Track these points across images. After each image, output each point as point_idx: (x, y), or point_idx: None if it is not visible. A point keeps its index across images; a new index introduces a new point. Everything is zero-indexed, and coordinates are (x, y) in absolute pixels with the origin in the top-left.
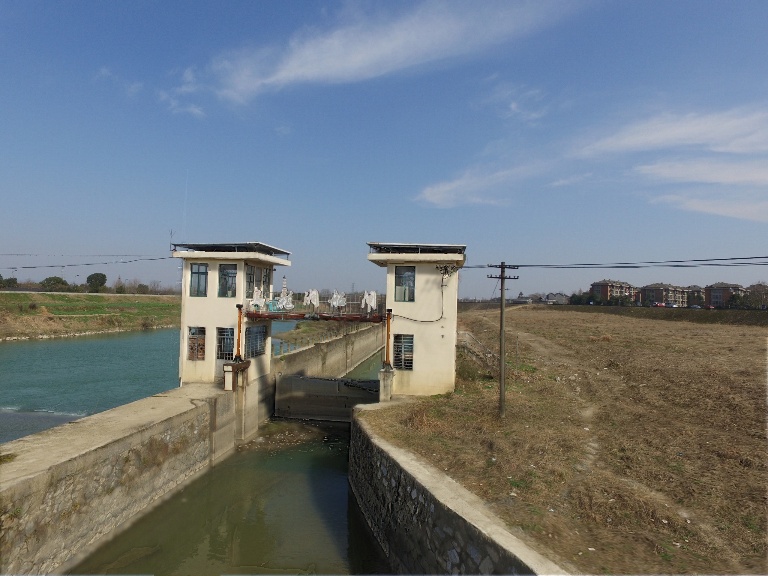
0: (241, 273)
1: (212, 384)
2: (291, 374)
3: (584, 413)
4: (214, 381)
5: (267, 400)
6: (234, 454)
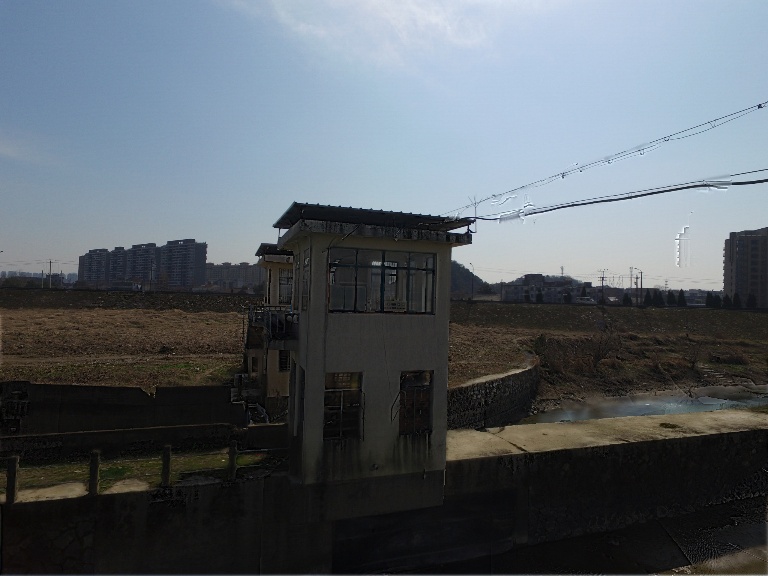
0: None
1: None
2: None
3: None
4: None
5: None
6: None
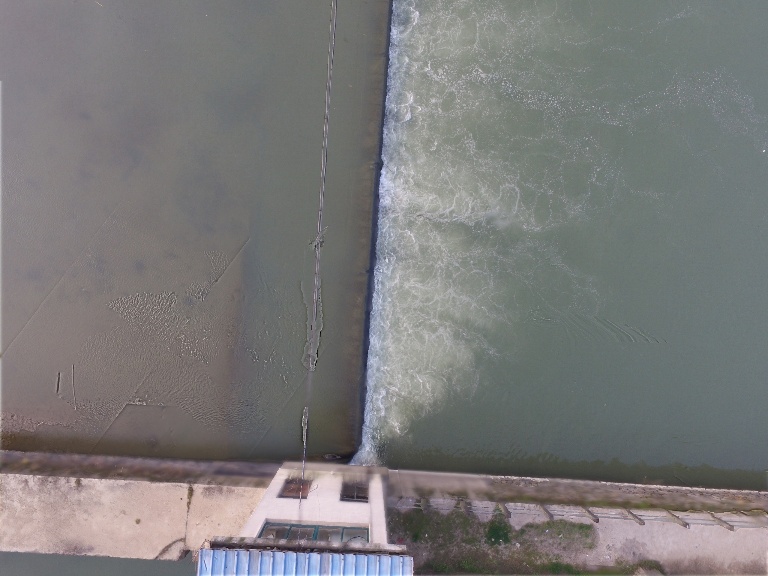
0: None
1: None
2: None
3: None
4: None
5: None
6: None
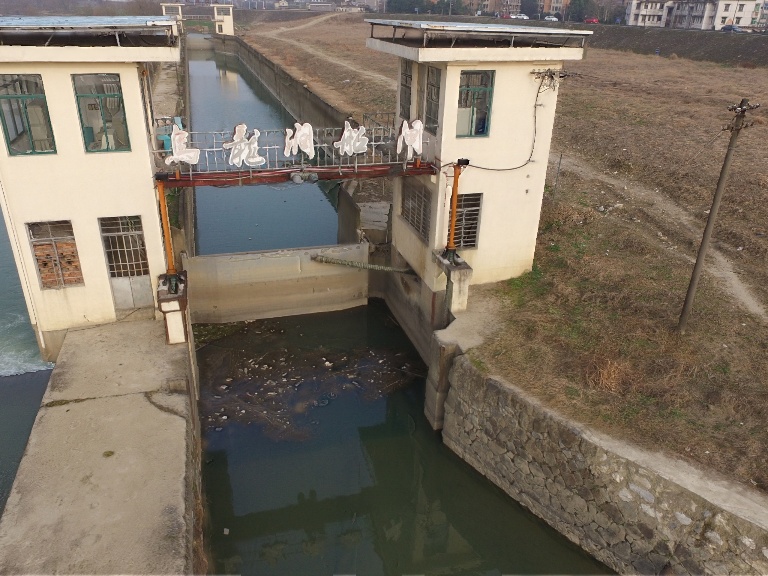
0: (135, 95)
1: (118, 327)
2: (188, 243)
3: (740, 295)
4: (116, 318)
5: None
6: (220, 443)
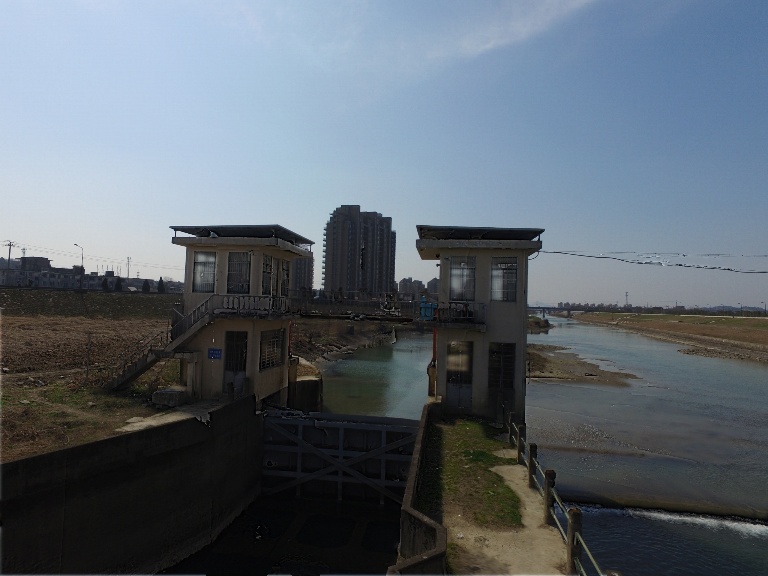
0: None
1: None
2: None
3: None
4: None
5: None
6: None
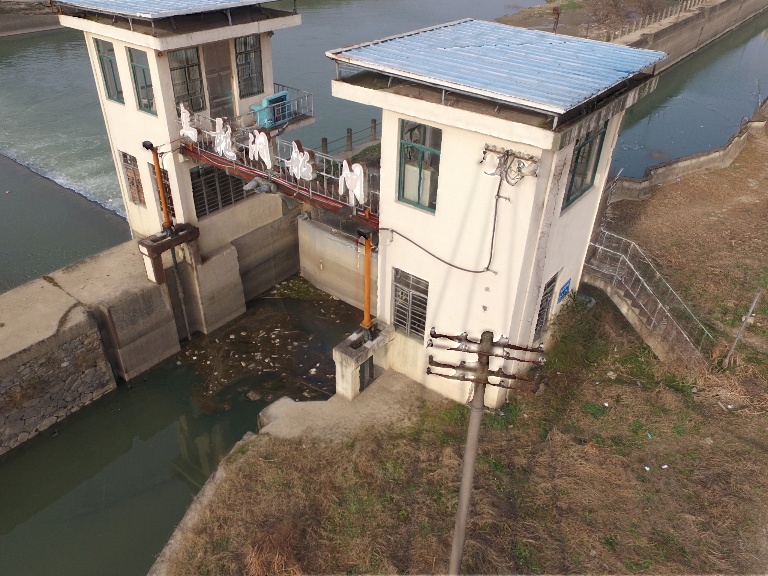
0: (155, 72)
1: None
2: None
3: None
4: None
5: (282, 256)
6: (164, 372)
